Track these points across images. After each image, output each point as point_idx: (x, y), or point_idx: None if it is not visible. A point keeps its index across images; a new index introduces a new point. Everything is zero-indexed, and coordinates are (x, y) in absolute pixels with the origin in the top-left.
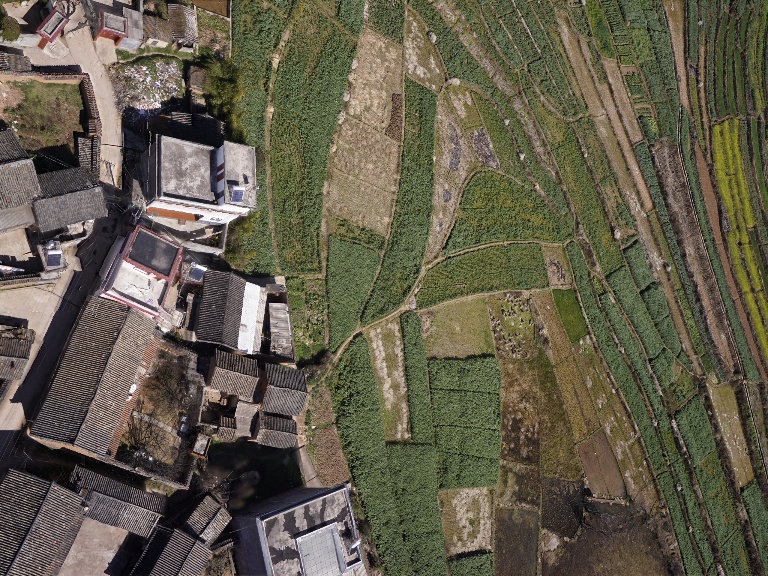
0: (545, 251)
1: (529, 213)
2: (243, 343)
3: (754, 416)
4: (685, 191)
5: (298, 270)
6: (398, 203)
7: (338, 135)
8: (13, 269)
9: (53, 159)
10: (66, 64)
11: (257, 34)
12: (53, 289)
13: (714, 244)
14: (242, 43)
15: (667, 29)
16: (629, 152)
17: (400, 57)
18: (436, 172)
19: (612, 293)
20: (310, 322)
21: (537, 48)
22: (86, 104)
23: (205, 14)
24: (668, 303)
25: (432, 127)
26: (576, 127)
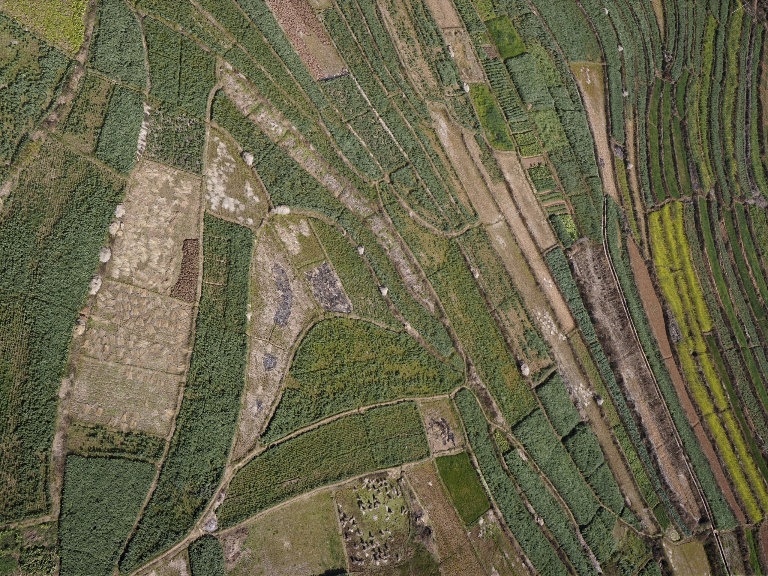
0: (423, 408)
1: (398, 362)
2: None
3: (732, 575)
4: (617, 299)
5: (8, 517)
6: (188, 387)
7: (89, 310)
8: None
9: None
10: None
11: None
12: None
13: (660, 360)
14: None
15: (582, 106)
16: (538, 262)
17: (197, 190)
18: (253, 332)
19: (522, 448)
20: None
21: (403, 152)
22: None
23: None
24: (602, 447)
25: (245, 275)
26: (462, 242)
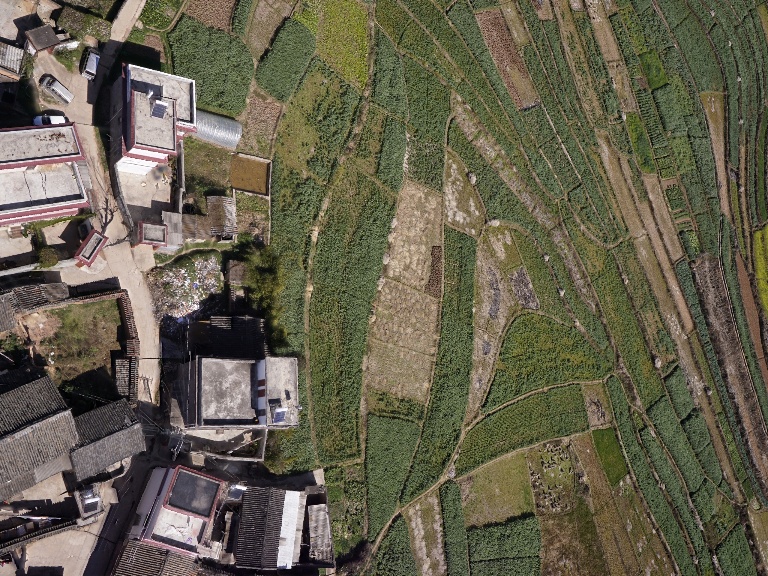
0: (585, 390)
1: (569, 352)
2: (282, 558)
3: None
4: (726, 306)
5: (337, 458)
6: (438, 366)
7: (377, 303)
8: (49, 518)
9: (91, 397)
10: (103, 278)
11: (296, 208)
12: (89, 528)
13: (755, 360)
14: (281, 221)
15: (708, 134)
16: (669, 271)
17: (440, 205)
18: (475, 324)
19: (653, 427)
20: (349, 513)
21: (577, 174)
22: (124, 319)
23: (244, 196)
24: (709, 430)
25: (472, 277)
26: (616, 253)
